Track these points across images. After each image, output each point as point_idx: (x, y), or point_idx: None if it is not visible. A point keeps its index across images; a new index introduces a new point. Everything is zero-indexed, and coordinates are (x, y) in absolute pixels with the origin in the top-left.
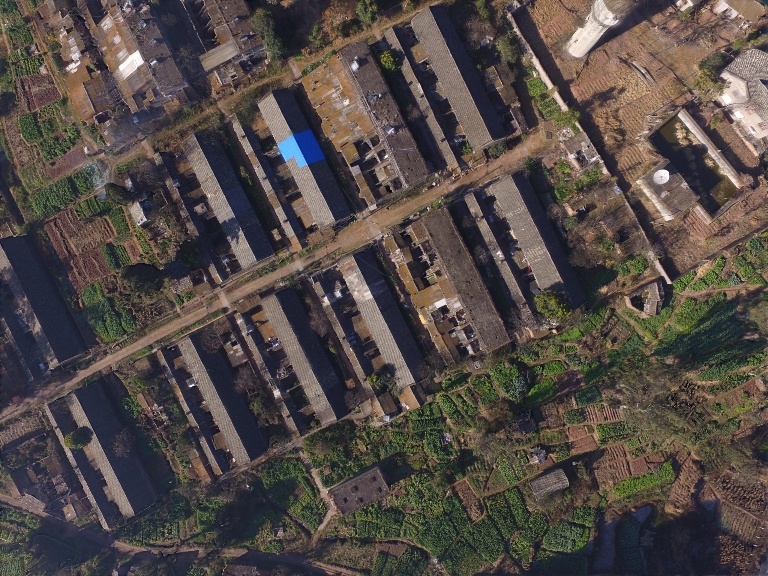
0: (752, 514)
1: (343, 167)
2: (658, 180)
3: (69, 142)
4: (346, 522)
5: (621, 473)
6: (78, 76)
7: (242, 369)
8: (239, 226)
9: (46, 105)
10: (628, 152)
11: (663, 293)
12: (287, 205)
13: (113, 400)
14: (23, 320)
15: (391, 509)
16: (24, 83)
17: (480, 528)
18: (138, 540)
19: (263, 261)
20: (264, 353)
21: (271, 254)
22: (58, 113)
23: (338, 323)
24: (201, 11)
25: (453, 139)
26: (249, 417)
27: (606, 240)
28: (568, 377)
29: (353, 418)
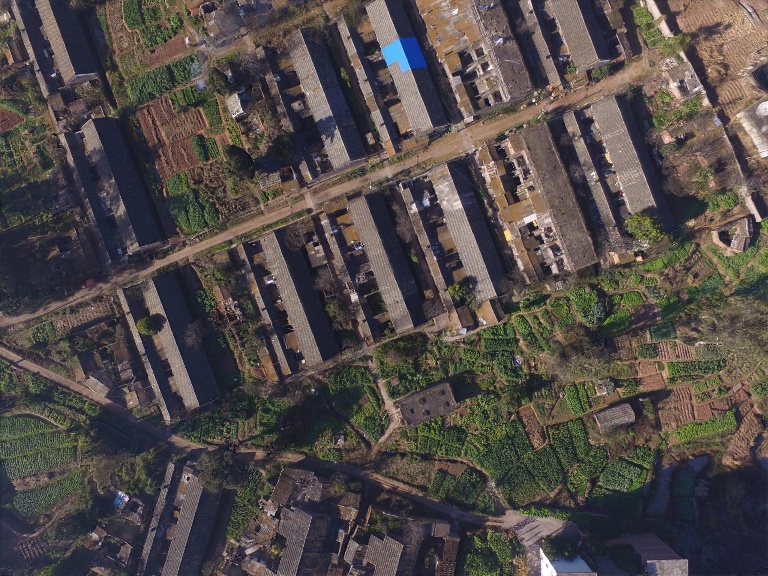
0: None
1: (443, 78)
2: (762, 112)
3: (171, 31)
4: (408, 436)
5: (685, 416)
6: None
7: (321, 270)
8: (336, 125)
9: None
10: (730, 86)
11: (752, 230)
12: (385, 109)
13: (186, 292)
14: (106, 203)
15: (455, 427)
16: None
17: (541, 456)
18: (196, 436)
19: (353, 164)
20: (345, 256)
21: (364, 156)
22: (163, 2)
23: (424, 231)
24: None
25: (557, 58)
26: (324, 319)
27: (704, 168)
28: (645, 310)
29: (426, 331)
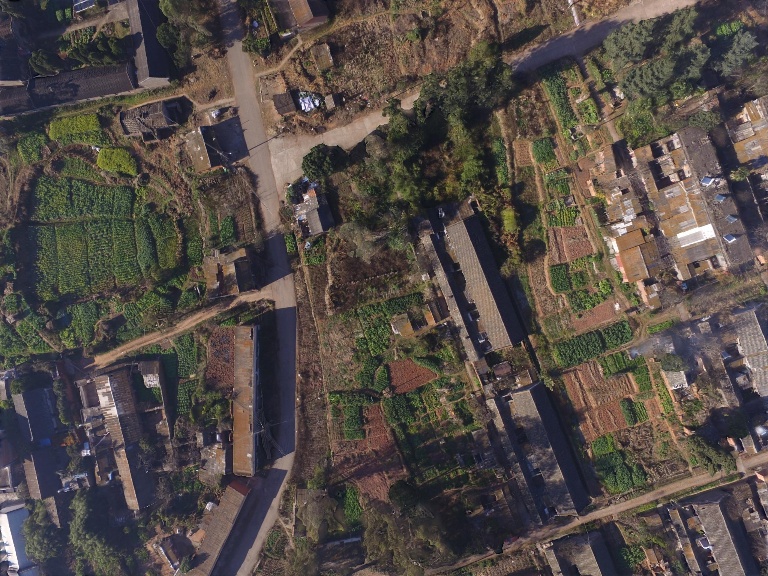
0: None
1: None
2: None
3: (601, 297)
4: None
5: None
6: (631, 238)
7: (756, 535)
8: None
9: (578, 257)
10: None
11: None
12: None
13: (608, 547)
14: (532, 465)
15: None
16: (556, 233)
17: None
18: None
19: None
20: None
21: None
22: (591, 267)
23: None
24: (760, 184)
25: None
26: None
27: None
28: None
29: None
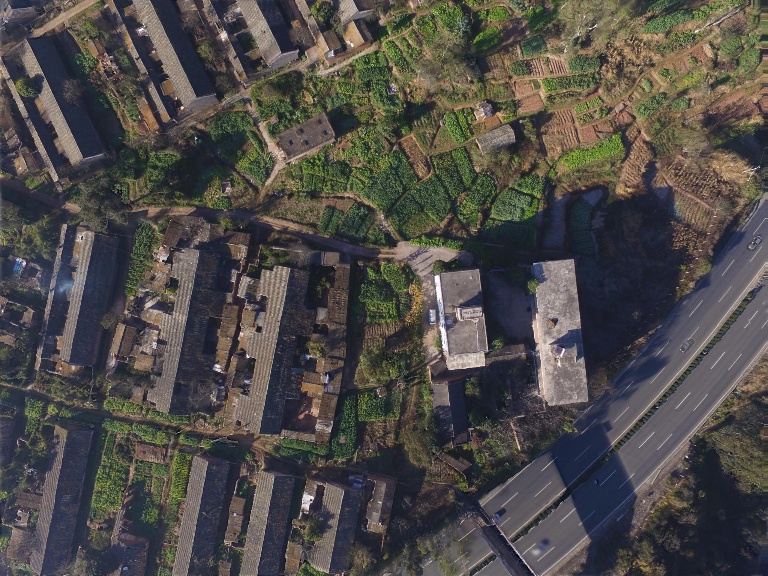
0: (705, 203)
1: None
2: None
3: None
4: (293, 176)
5: (569, 140)
6: None
7: (191, 15)
8: None
9: None
10: None
11: None
12: None
13: (66, 59)
14: None
15: (338, 162)
16: None
17: (427, 185)
18: None
19: None
20: None
21: None
22: None
23: None
24: None
25: None
26: (197, 61)
27: None
28: (513, 25)
29: (300, 69)
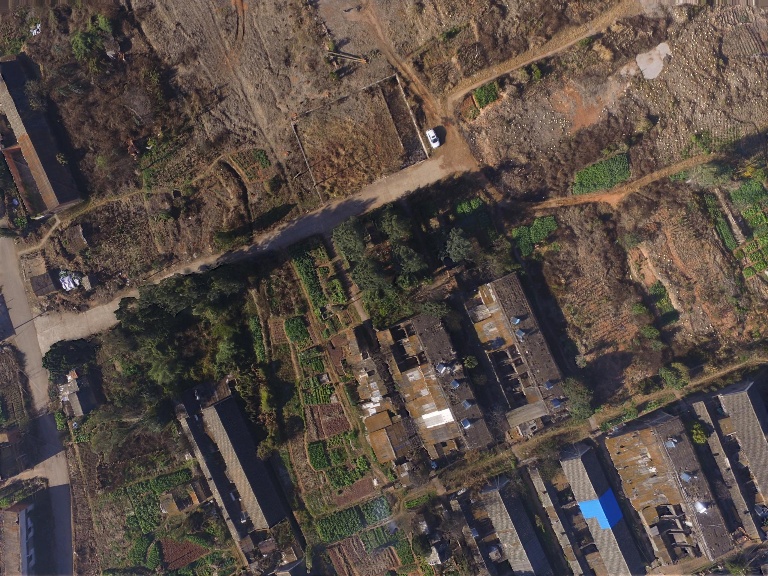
0: None
1: (635, 520)
2: None
3: (359, 474)
4: None
5: None
6: (379, 420)
7: None
8: None
9: (335, 434)
10: None
11: None
12: (582, 558)
13: None
14: None
15: None
16: (313, 410)
17: None
18: None
19: None
20: None
21: None
22: (348, 443)
23: None
24: (503, 361)
25: (754, 509)
26: None
27: None
28: None
29: None
